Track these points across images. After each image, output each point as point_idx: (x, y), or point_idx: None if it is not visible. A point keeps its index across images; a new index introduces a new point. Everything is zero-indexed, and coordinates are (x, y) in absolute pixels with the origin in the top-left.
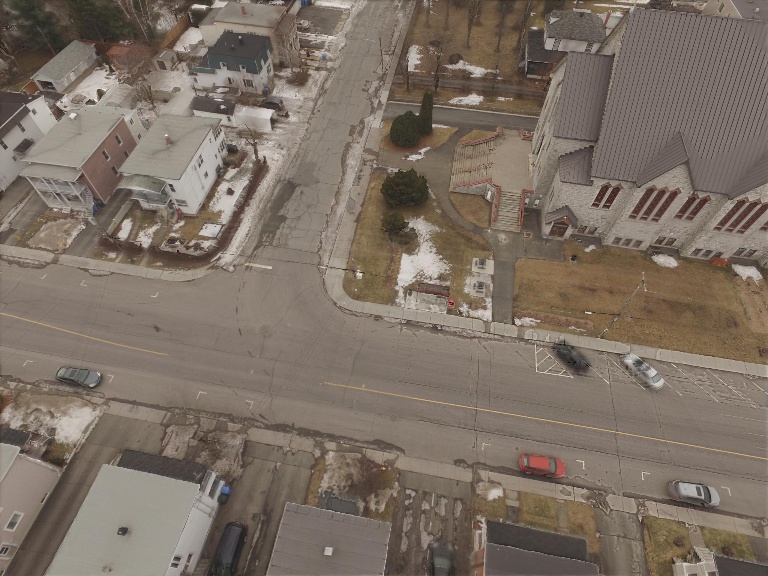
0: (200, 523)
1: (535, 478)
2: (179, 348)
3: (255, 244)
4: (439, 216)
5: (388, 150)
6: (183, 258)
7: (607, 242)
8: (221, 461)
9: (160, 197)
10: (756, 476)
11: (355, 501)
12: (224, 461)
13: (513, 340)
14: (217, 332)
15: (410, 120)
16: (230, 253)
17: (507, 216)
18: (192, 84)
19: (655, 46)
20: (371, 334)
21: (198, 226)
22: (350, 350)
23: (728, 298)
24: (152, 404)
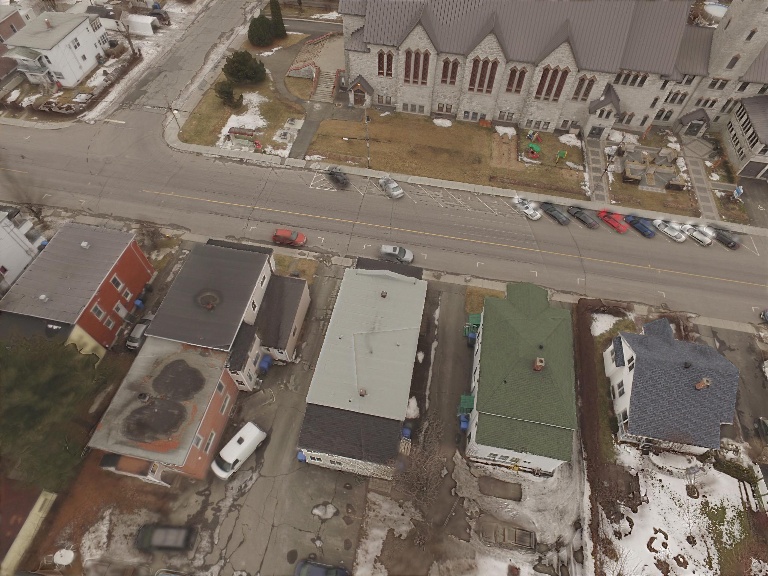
0: (15, 250)
1: (283, 246)
2: (37, 169)
3: (116, 108)
4: (271, 92)
5: (247, 49)
6: (54, 114)
7: (399, 109)
8: (49, 231)
9: (37, 66)
10: (450, 248)
11: None
12: (51, 231)
13: (300, 169)
14: (69, 160)
15: (260, 21)
16: (94, 112)
17: (323, 90)
18: (94, 0)
19: None
20: (189, 163)
21: (73, 95)
22: (169, 172)
23: (482, 146)
24: (8, 201)
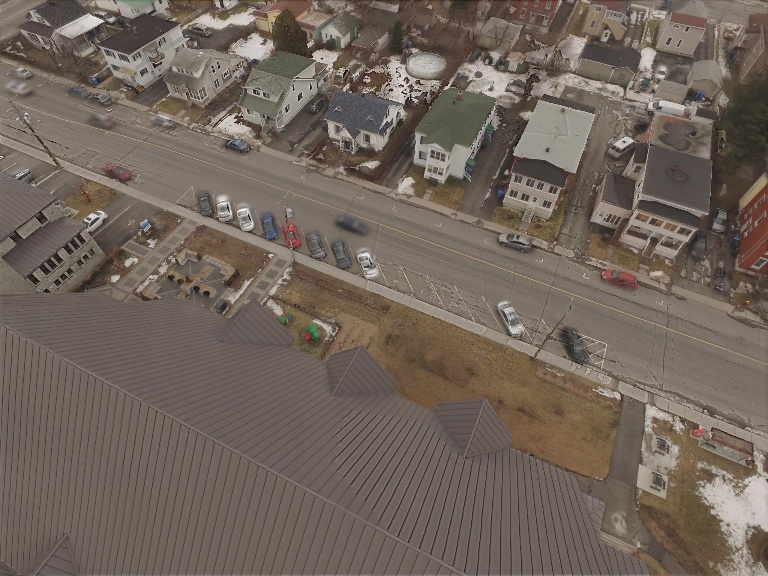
0: None
1: None
2: None
3: None
4: None
5: None
6: None
7: None
8: None
9: None
10: (461, 242)
11: (764, 291)
12: None
13: (624, 379)
14: None
15: None
16: None
17: None
18: None
19: (548, 573)
20: None
21: None
22: None
23: None
24: None
